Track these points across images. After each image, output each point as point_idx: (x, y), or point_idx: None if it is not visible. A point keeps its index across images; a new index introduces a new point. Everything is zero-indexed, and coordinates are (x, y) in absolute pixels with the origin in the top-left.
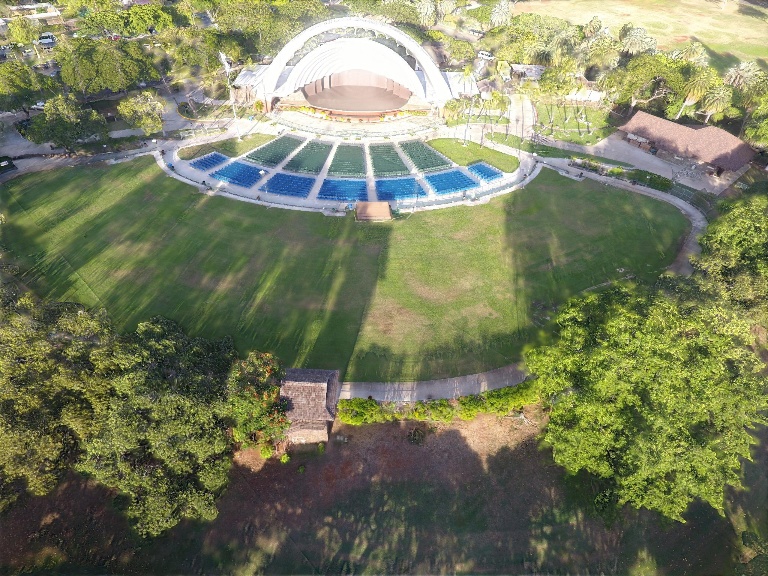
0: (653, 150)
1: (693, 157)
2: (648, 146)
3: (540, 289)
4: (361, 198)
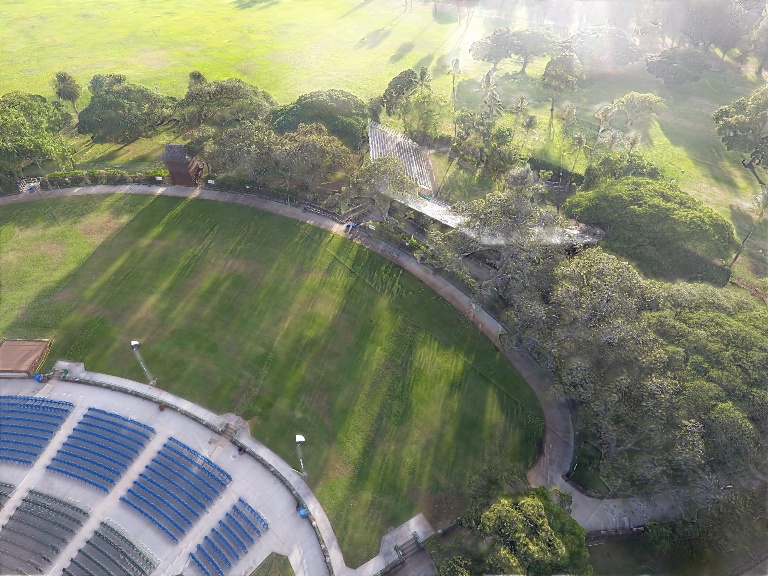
0: None
1: None
2: None
3: None
4: (7, 401)
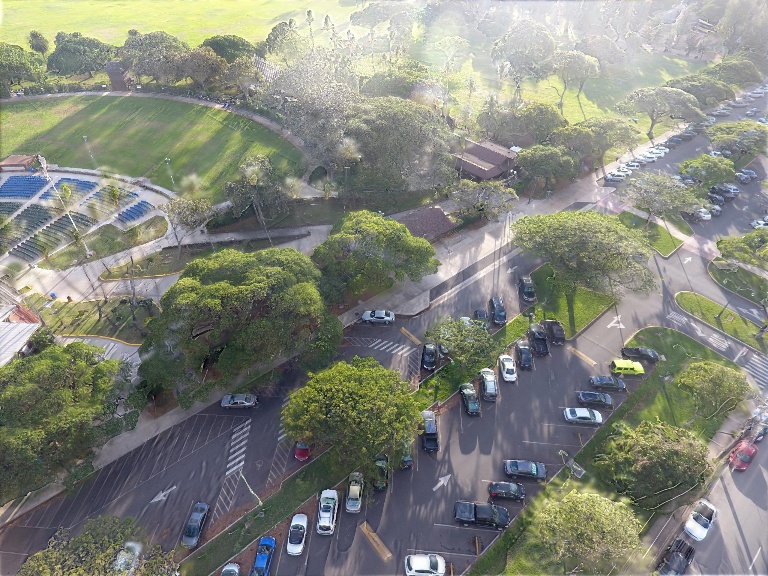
0: None
1: None
2: None
3: None
4: None
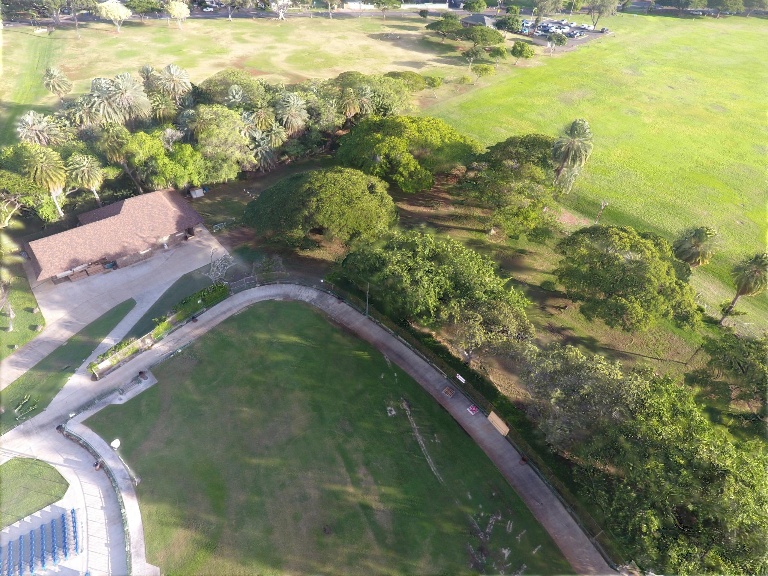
0: (108, 265)
1: (157, 239)
2: (98, 266)
3: (439, 544)
4: None
